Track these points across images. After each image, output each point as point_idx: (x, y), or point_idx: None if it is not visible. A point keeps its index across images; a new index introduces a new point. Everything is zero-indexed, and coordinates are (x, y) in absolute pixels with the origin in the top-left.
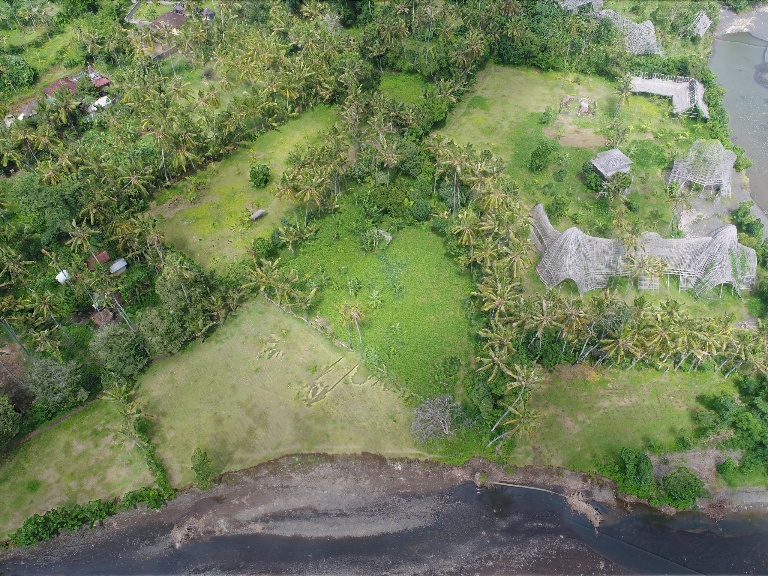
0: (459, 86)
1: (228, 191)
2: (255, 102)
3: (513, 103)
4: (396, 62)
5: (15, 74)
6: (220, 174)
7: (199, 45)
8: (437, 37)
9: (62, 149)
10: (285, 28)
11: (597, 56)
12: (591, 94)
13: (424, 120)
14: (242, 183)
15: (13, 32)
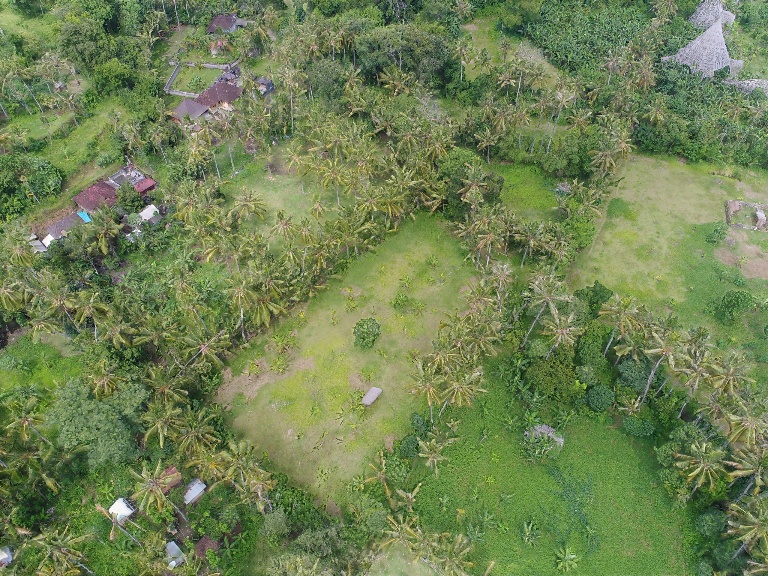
0: (601, 192)
1: (324, 352)
2: (352, 227)
3: (664, 209)
4: (508, 152)
5: (38, 181)
6: (309, 323)
7: (263, 132)
8: (547, 112)
9: (112, 321)
10: (367, 108)
11: (764, 146)
12: (760, 196)
13: (570, 247)
14: (341, 339)
15: (32, 117)
